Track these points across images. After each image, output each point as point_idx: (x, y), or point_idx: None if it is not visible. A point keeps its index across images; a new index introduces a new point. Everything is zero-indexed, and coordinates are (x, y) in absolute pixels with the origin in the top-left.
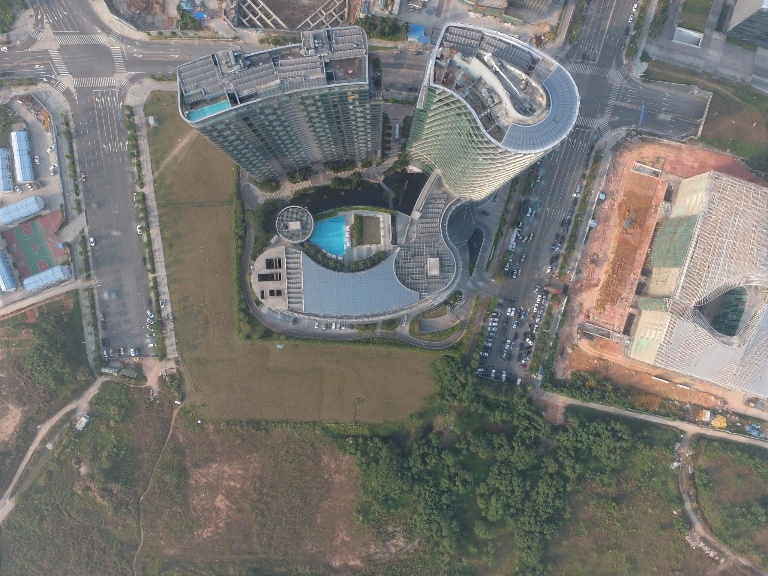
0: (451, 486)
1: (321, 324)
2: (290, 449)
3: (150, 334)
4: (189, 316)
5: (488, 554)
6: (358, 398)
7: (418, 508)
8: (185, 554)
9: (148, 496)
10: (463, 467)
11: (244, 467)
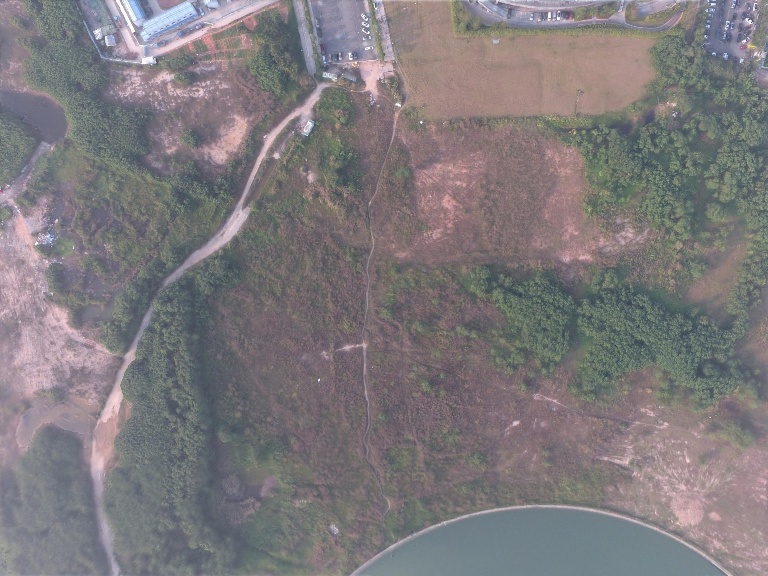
0: (680, 170)
1: (536, 16)
2: (514, 144)
3: (366, 37)
4: (403, 17)
5: (721, 238)
6: (578, 90)
7: (648, 194)
8: (417, 256)
9: (377, 199)
10: (691, 151)
11: (469, 166)
